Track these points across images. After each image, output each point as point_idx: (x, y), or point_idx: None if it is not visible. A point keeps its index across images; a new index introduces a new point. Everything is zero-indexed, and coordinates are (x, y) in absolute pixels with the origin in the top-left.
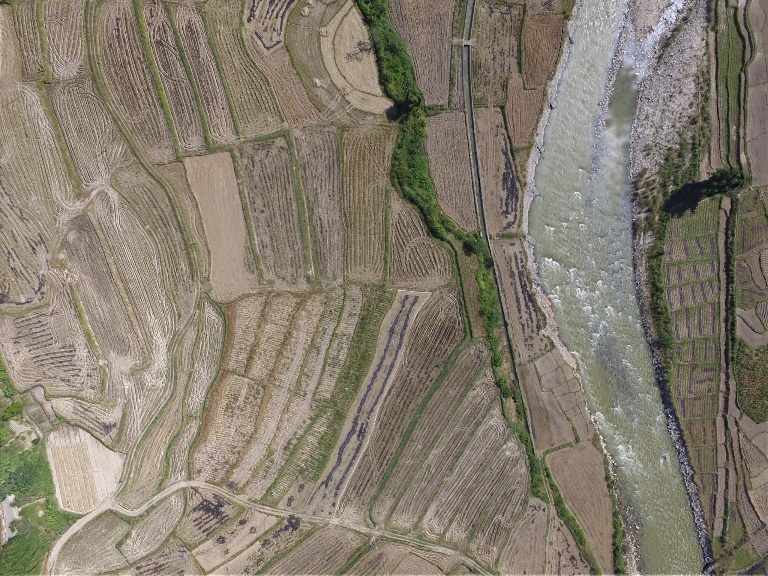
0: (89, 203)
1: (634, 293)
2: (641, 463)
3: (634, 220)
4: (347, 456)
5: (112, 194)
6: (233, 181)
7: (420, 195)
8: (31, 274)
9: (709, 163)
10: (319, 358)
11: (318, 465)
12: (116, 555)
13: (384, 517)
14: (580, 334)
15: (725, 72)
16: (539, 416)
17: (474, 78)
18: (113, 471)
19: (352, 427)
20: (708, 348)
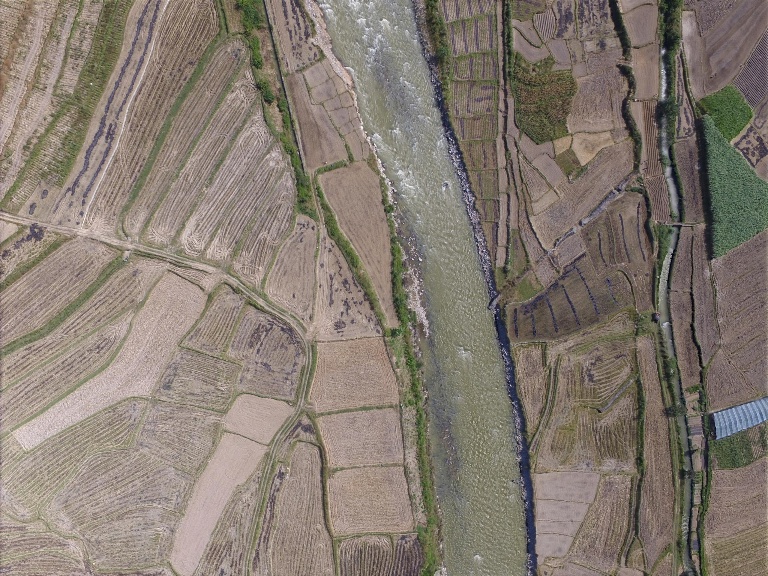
0: None
1: (410, 6)
2: (423, 191)
3: None
4: (95, 160)
5: None
6: None
7: None
8: None
9: None
10: (59, 48)
11: (62, 168)
12: None
13: (138, 230)
14: (355, 48)
15: None
16: (309, 131)
17: None
18: None
19: (99, 128)
20: (486, 64)
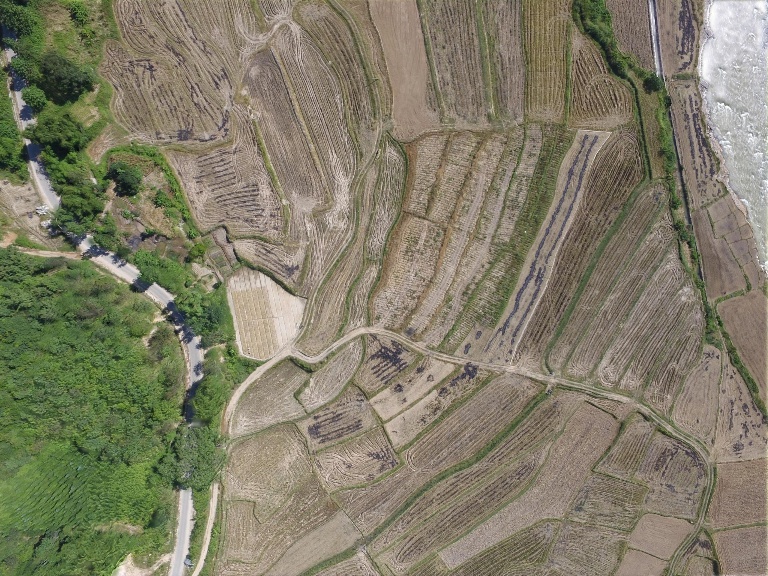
0: (271, 37)
1: None
2: None
3: None
4: (524, 302)
5: (294, 28)
6: (415, 15)
7: (603, 29)
8: (215, 110)
9: None
10: (498, 200)
11: (496, 311)
12: (294, 405)
13: (560, 365)
14: (750, 181)
15: None
16: (711, 263)
17: None
18: (293, 316)
19: (530, 272)
20: None
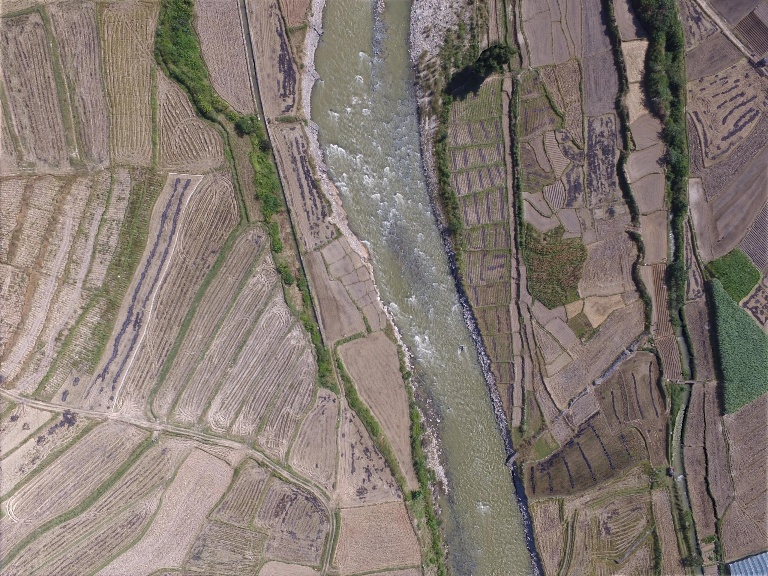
0: None
1: (423, 180)
2: (439, 355)
3: (418, 104)
4: (123, 347)
5: None
6: None
7: (185, 73)
8: None
9: (488, 44)
10: (88, 245)
11: (92, 357)
12: None
13: (166, 411)
14: (370, 222)
15: None
16: (328, 306)
17: None
18: None
19: (127, 317)
20: (498, 234)
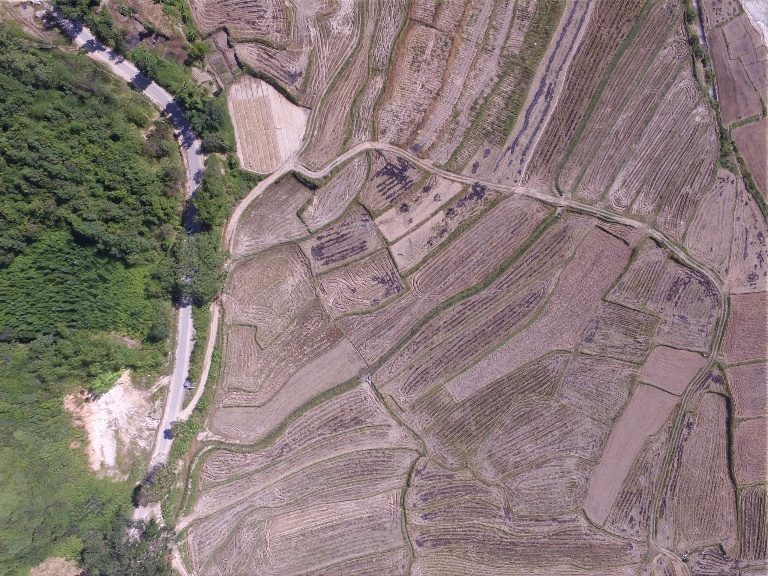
0: None
1: None
2: None
3: None
4: (534, 119)
5: None
6: None
7: None
8: None
9: None
10: (508, 10)
11: (505, 127)
12: (297, 224)
13: (570, 186)
14: (767, 2)
15: None
16: (726, 86)
17: None
18: (296, 128)
19: (540, 87)
20: None
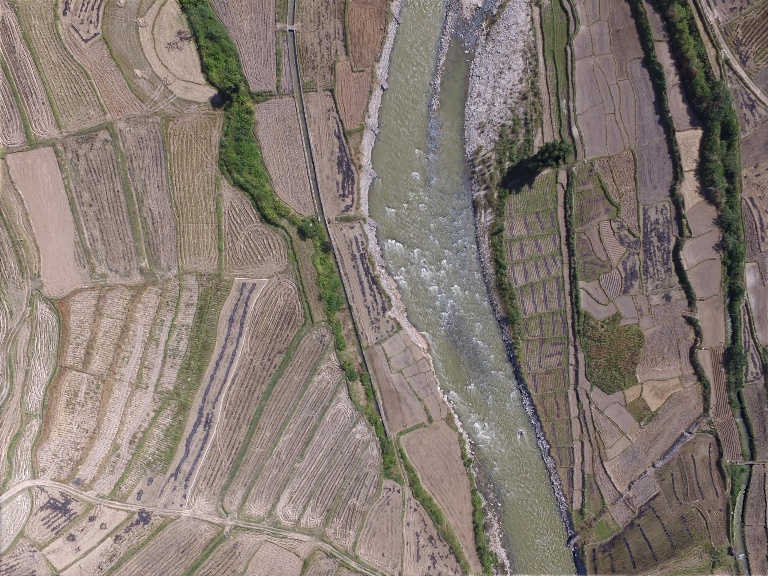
0: None
1: (480, 271)
2: (499, 440)
3: (474, 198)
4: (195, 447)
5: None
6: (58, 176)
7: (249, 182)
8: None
9: (542, 138)
10: (159, 350)
11: (165, 457)
12: None
13: (237, 506)
14: (428, 314)
15: (551, 46)
16: (390, 398)
17: (302, 63)
18: None
19: (197, 418)
20: (555, 322)
